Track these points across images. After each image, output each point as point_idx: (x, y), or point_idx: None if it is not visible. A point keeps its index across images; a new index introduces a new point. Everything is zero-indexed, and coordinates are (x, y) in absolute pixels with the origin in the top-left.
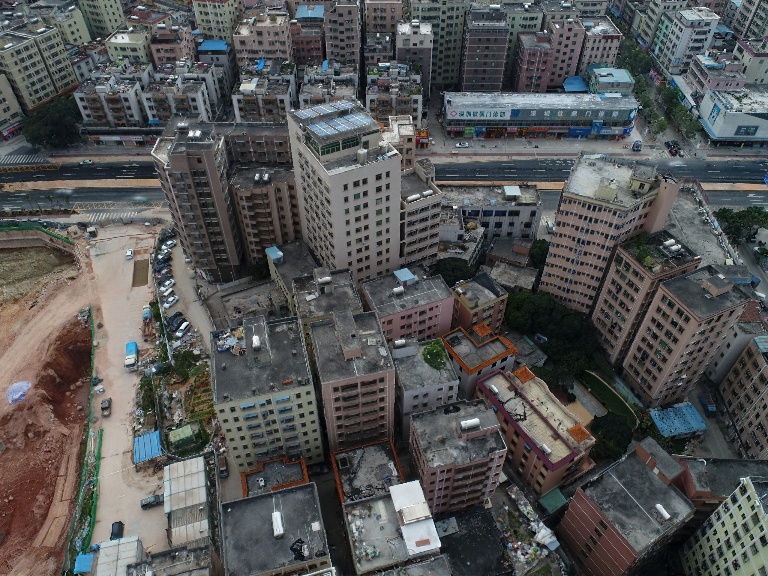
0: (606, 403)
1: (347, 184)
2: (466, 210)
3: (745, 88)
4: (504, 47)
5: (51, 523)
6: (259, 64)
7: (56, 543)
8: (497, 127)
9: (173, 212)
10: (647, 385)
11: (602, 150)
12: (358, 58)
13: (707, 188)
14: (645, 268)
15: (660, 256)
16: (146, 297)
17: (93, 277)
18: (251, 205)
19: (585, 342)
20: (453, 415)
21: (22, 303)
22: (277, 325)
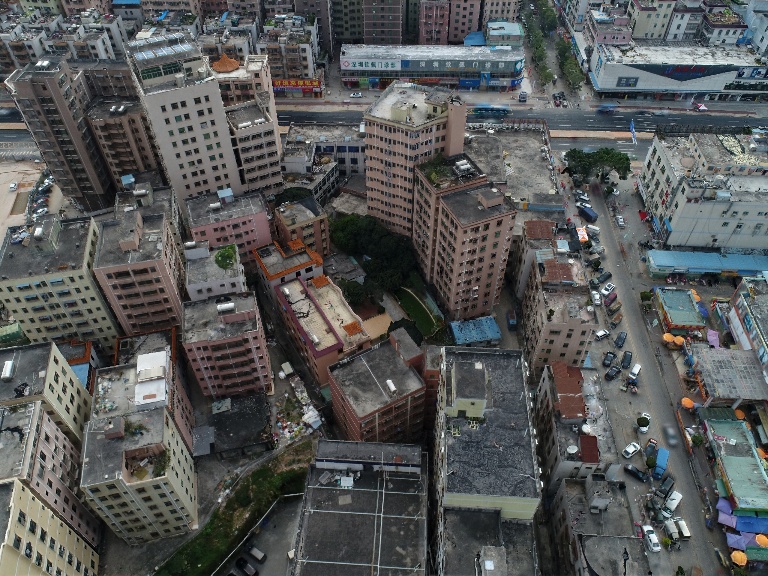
0: (413, 315)
1: (165, 106)
2: (321, 146)
3: (635, 42)
4: (399, 0)
5: None
6: (163, 15)
7: None
8: (390, 78)
9: (35, 141)
10: (447, 297)
11: (490, 101)
12: (258, 10)
13: (579, 135)
14: (433, 184)
15: (452, 175)
16: (19, 223)
17: None
18: (107, 135)
19: (401, 261)
20: None
21: None
22: (72, 224)
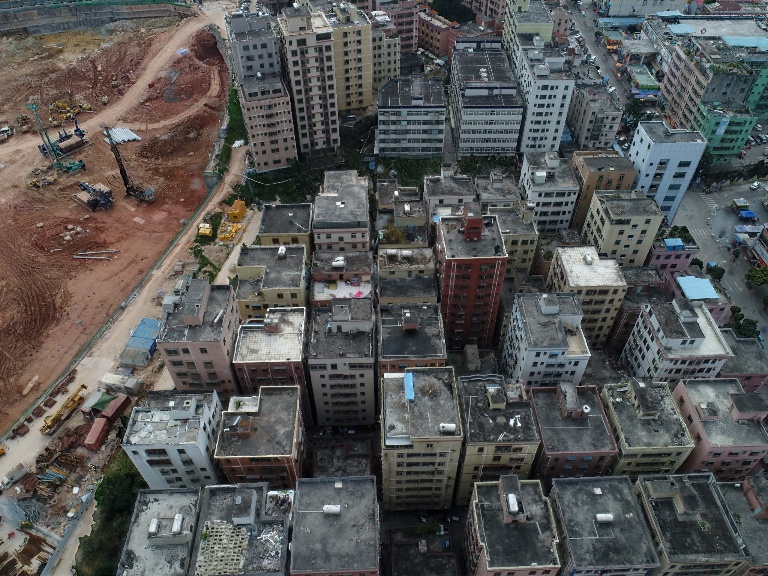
0: None
1: None
2: None
3: None
4: None
5: (212, 90)
6: None
7: (217, 94)
8: None
9: None
10: None
11: None
12: None
13: None
14: None
15: None
16: None
17: (207, 16)
18: None
19: (468, 17)
20: (397, 4)
21: (169, 29)
22: None
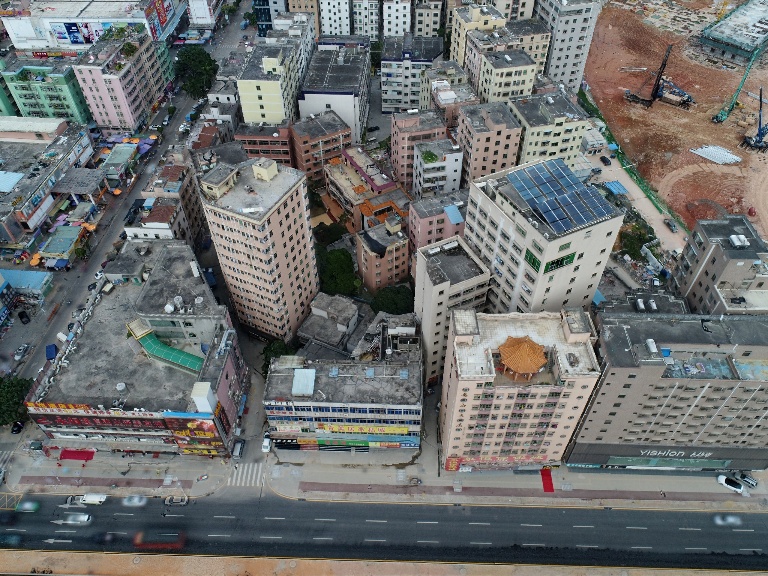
0: None
1: None
2: None
3: None
4: None
5: None
6: None
7: None
8: None
9: None
10: None
11: None
12: None
13: None
14: None
15: None
16: None
17: None
18: None
19: None
20: None
21: None
22: None
